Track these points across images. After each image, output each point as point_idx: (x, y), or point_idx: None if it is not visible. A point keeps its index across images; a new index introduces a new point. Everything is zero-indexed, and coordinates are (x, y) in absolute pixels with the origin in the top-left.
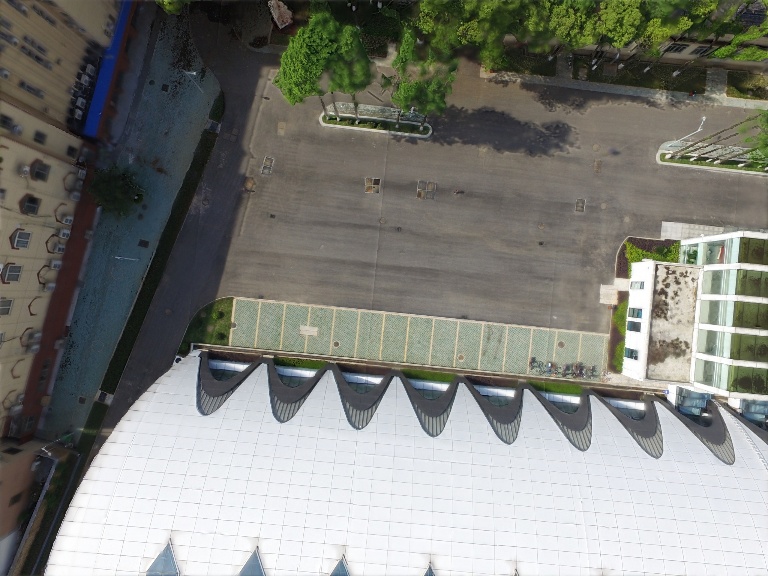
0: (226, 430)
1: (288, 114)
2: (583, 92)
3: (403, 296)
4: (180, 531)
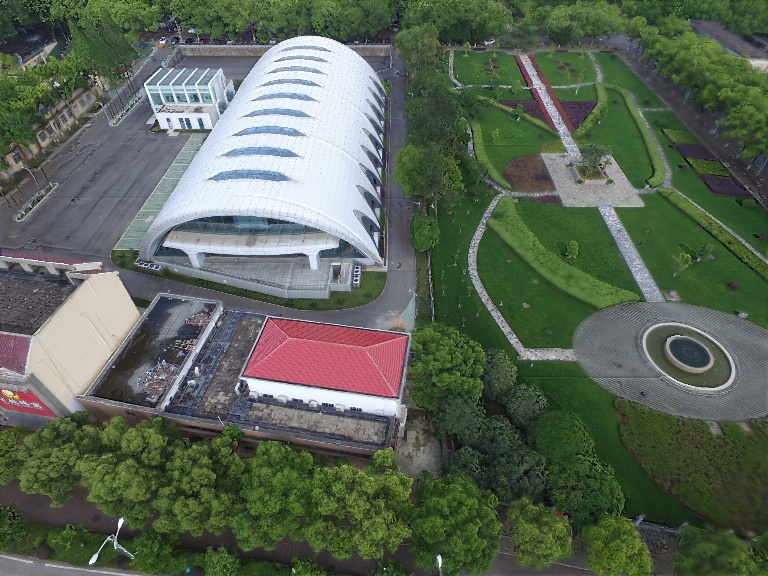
0: (170, 196)
1: (5, 234)
2: None
3: (145, 188)
4: (203, 179)
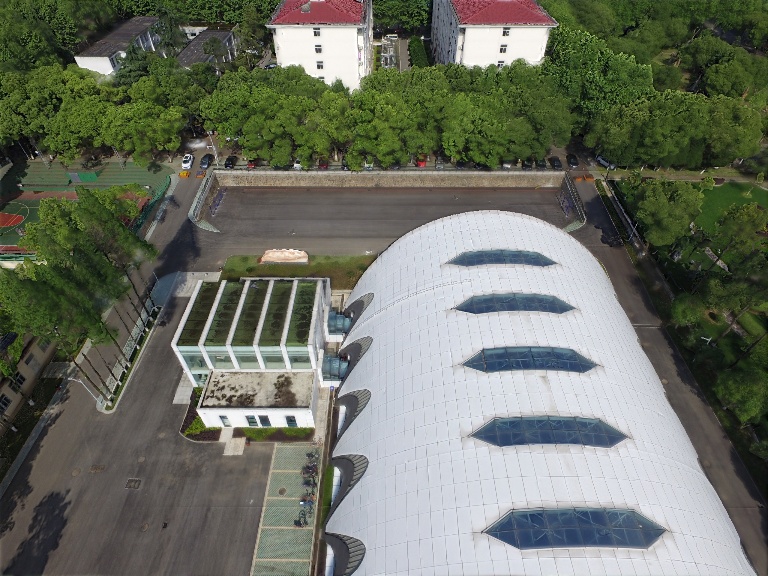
0: None
1: None
2: (7, 492)
3: None
4: None
